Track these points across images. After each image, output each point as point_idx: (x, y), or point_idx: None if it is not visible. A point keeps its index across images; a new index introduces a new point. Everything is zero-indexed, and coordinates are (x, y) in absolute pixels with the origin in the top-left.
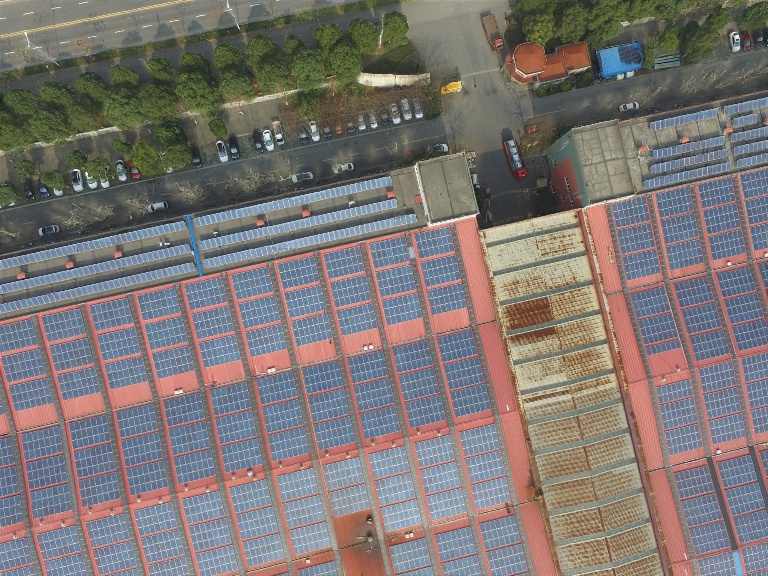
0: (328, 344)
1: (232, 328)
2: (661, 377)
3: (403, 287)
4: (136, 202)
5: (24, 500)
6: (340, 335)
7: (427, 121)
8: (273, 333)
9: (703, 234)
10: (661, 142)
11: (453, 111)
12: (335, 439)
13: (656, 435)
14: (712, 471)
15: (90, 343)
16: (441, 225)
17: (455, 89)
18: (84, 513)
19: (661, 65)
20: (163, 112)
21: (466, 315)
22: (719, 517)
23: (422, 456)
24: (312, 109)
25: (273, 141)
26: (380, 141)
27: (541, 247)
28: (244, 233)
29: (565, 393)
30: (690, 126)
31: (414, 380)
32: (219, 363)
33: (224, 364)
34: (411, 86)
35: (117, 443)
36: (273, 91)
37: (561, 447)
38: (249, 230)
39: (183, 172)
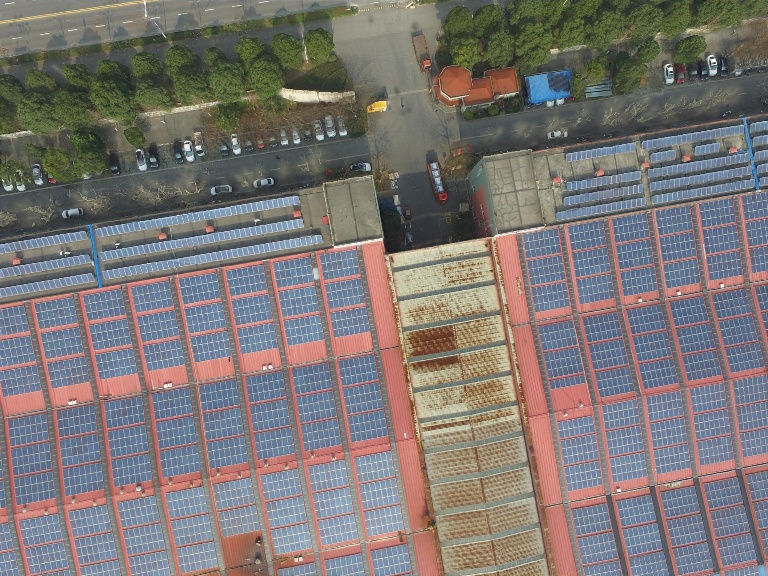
0: (227, 362)
1: (130, 341)
2: (563, 412)
3: (306, 308)
4: (38, 209)
5: None
6: (240, 353)
7: (351, 139)
8: (171, 348)
9: (615, 269)
10: (577, 174)
11: (378, 130)
12: (227, 458)
13: (555, 470)
14: (611, 509)
15: None
16: (347, 247)
17: (380, 108)
18: None
19: (592, 94)
20: (76, 119)
21: (369, 339)
22: (615, 556)
23: (315, 480)
24: (230, 122)
25: (193, 152)
26: (303, 157)
27: (448, 274)
28: (146, 246)
29: (464, 423)
30: (607, 159)
31: (312, 403)
32: (115, 376)
33: (120, 377)
34: (336, 103)
35: (7, 451)
36: (191, 102)
37: (458, 478)
38: (151, 243)
39: (101, 179)
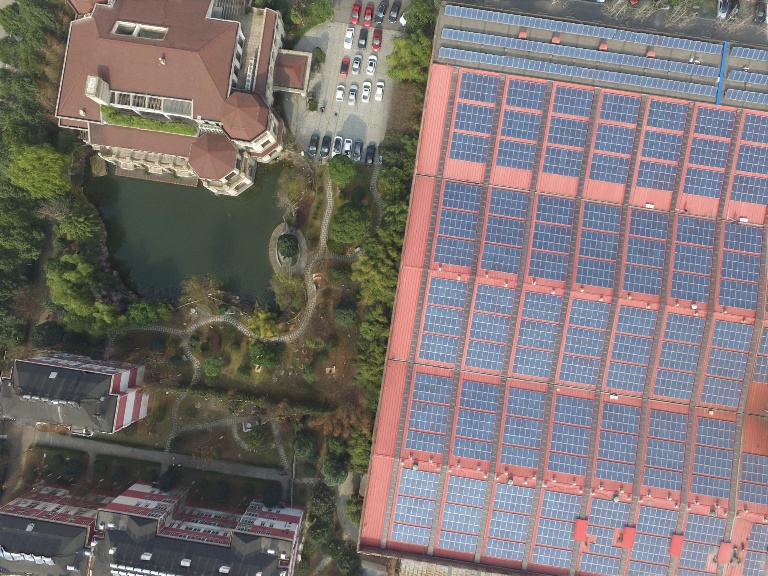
0: None
1: (724, 165)
2: None
3: None
4: (685, 11)
5: (477, 248)
6: None
7: None
8: (760, 185)
9: None
10: None
11: None
12: None
13: None
14: None
15: (588, 128)
16: None
17: None
18: (527, 282)
19: None
20: None
21: None
22: None
23: None
24: None
25: None
26: None
27: None
28: None
29: None
30: None
31: None
32: (698, 194)
33: (701, 197)
34: None
35: (577, 230)
36: None
37: None
38: None
39: None
